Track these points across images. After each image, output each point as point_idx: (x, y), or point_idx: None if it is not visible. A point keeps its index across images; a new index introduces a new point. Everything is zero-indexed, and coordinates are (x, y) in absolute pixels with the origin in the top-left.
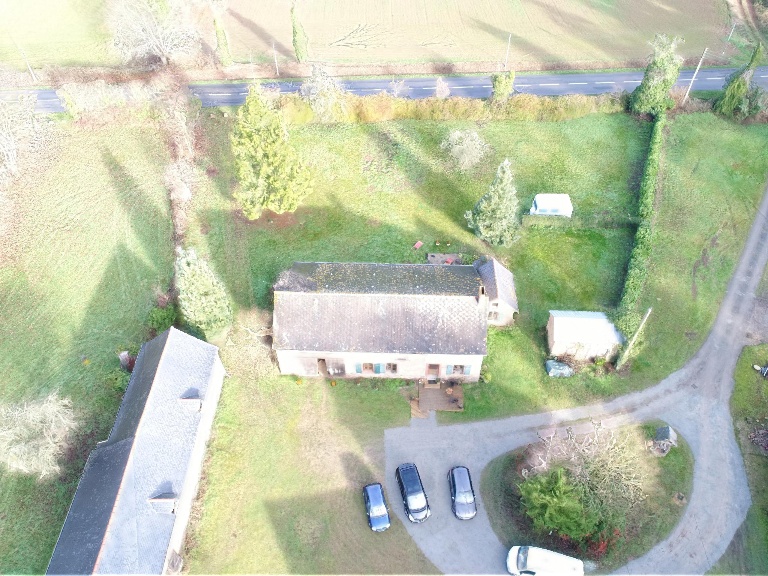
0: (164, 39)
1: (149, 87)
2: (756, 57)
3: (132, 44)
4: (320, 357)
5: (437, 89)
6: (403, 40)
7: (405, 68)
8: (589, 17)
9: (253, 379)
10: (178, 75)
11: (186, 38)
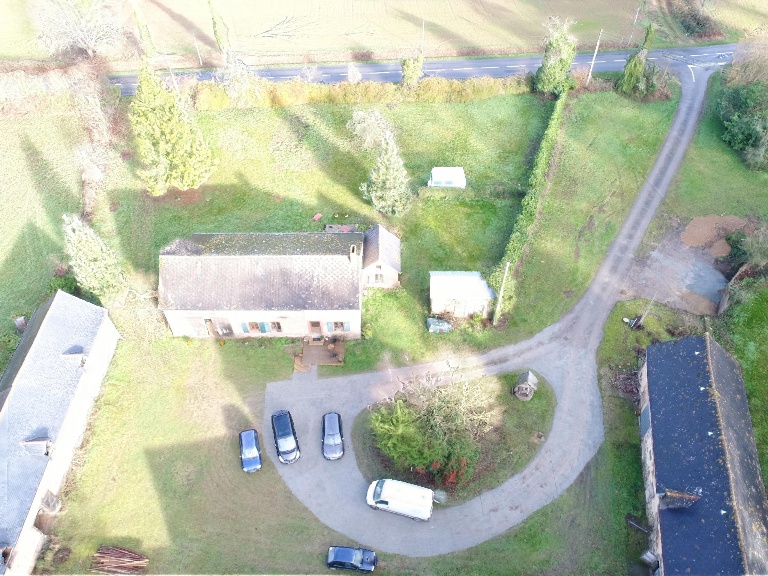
0: (89, 32)
1: (67, 76)
2: (649, 37)
3: (55, 37)
4: (206, 317)
5: (348, 74)
6: (327, 30)
7: (325, 56)
8: (510, 6)
9: (147, 341)
10: (96, 64)
11: (110, 31)
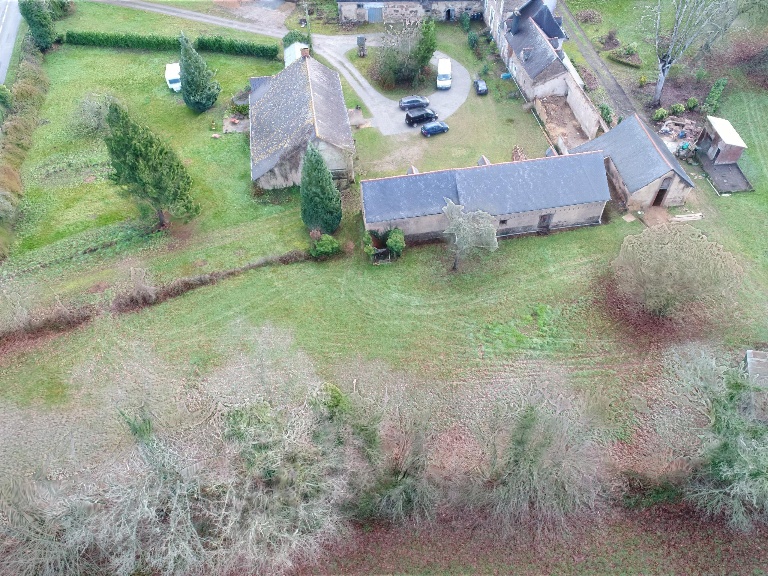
0: None
1: None
2: None
3: None
4: None
5: None
6: None
7: None
8: None
9: None
10: None
11: None
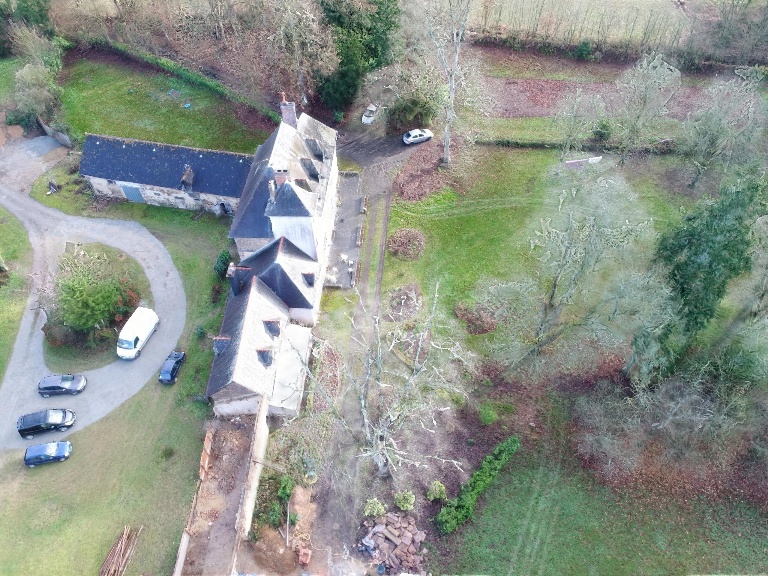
0: None
1: None
2: None
3: None
4: None
5: None
6: None
7: None
8: None
9: None
10: None
11: None
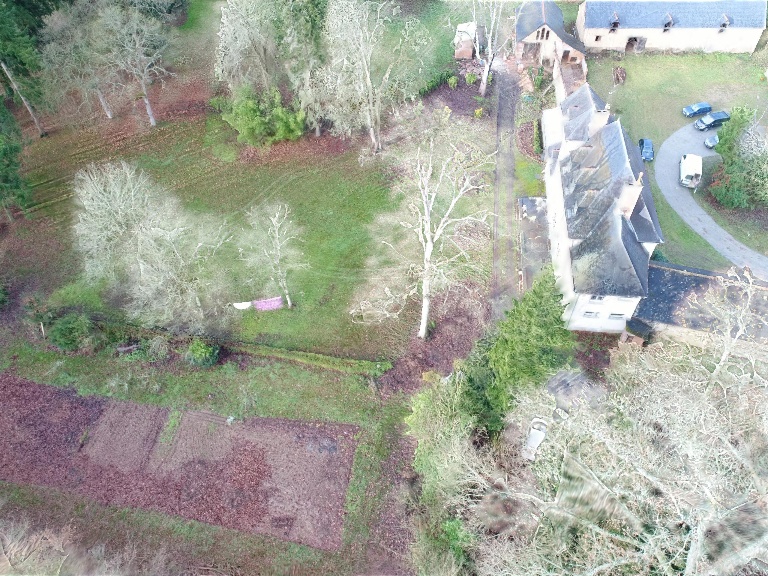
0: None
1: None
2: None
3: None
4: None
5: None
6: None
7: None
8: None
9: (754, 65)
10: None
11: None
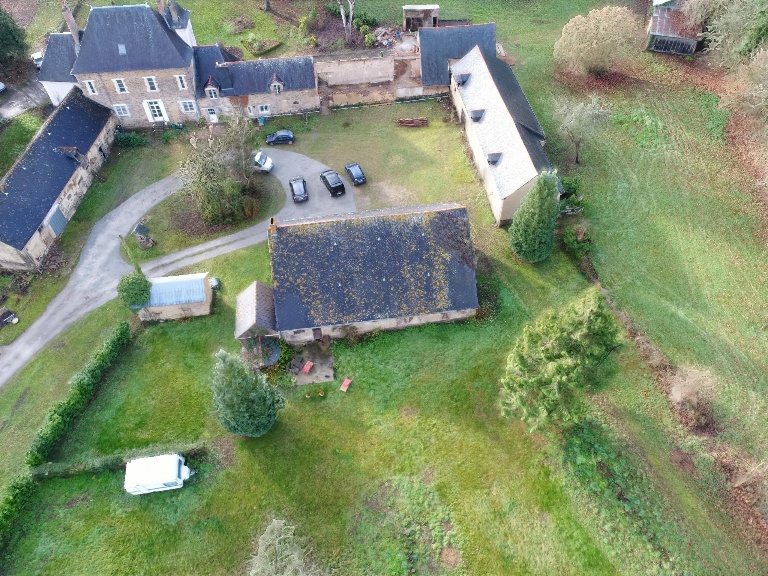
0: None
1: None
2: None
3: None
4: None
5: None
6: None
7: None
8: None
9: (473, 228)
10: None
11: None
